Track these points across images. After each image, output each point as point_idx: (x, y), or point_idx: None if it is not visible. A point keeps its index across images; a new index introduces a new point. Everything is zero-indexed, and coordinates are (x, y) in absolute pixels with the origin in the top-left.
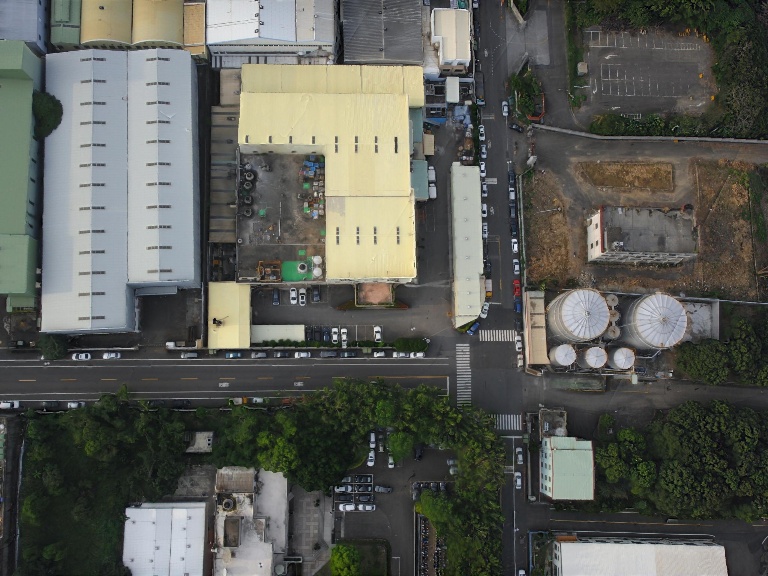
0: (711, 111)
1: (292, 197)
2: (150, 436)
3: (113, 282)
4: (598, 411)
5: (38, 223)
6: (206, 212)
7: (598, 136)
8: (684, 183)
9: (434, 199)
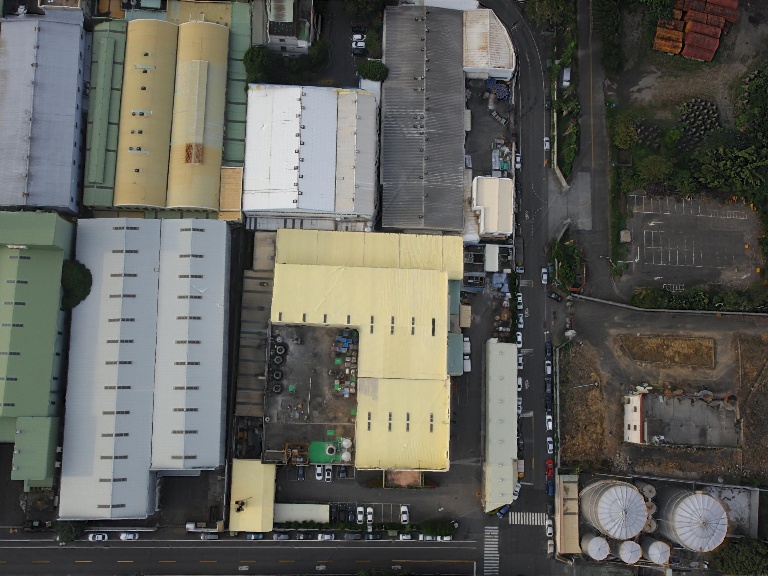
0: (757, 287)
1: (323, 373)
2: None
3: (135, 467)
4: None
5: (61, 399)
6: (233, 383)
7: (639, 308)
8: (726, 360)
9: (468, 371)
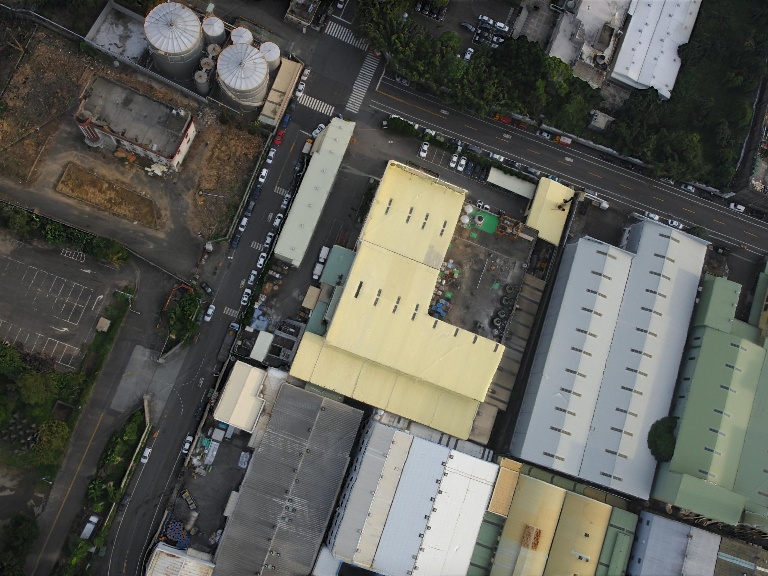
0: None
1: (465, 289)
2: (643, 136)
3: (645, 262)
4: (252, 5)
5: (689, 341)
6: (541, 309)
7: None
8: (52, 166)
9: None
